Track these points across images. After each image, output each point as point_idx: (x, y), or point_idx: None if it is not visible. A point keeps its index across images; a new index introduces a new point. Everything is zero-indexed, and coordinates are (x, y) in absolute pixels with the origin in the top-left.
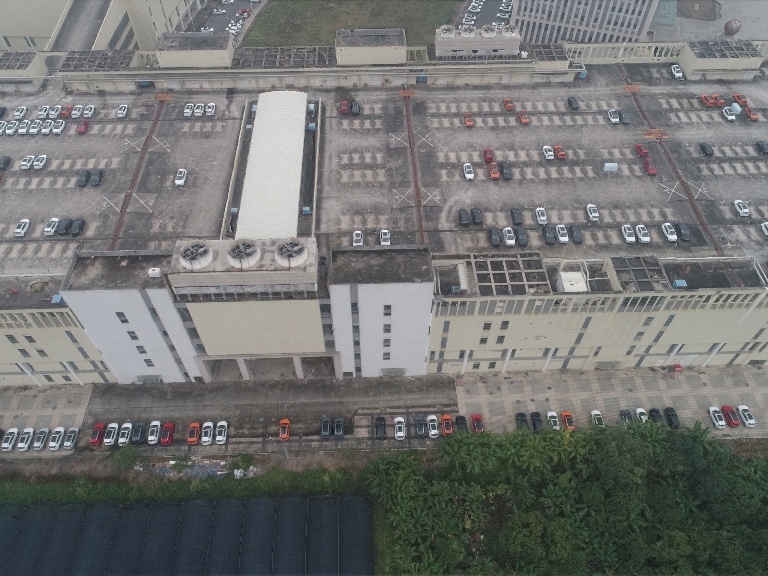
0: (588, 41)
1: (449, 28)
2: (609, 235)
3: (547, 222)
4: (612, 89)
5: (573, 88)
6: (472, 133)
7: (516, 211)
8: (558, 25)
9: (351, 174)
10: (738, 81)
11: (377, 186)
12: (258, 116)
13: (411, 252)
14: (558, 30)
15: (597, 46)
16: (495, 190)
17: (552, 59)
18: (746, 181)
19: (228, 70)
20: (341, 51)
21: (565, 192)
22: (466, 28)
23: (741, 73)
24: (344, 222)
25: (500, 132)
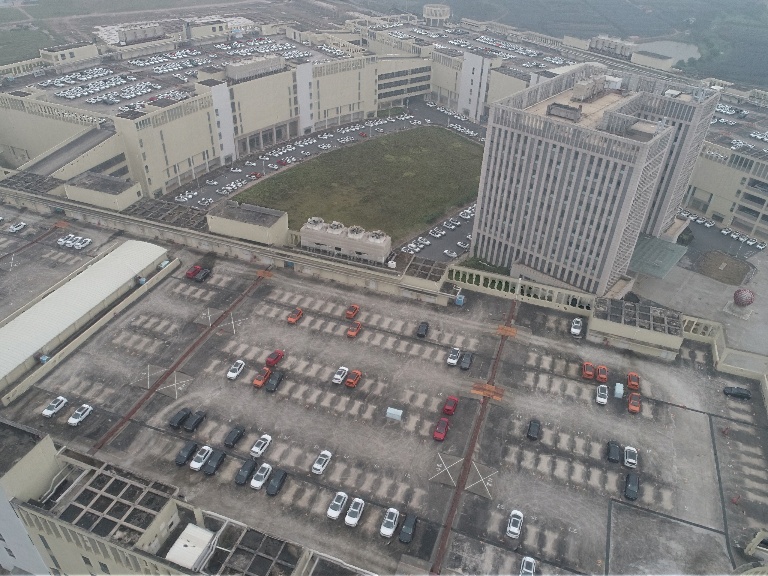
0: (547, 271)
1: (318, 220)
2: (318, 498)
3: (264, 455)
4: (484, 326)
5: (441, 313)
6: (287, 330)
7: (236, 430)
8: (517, 248)
9: (128, 337)
10: (651, 358)
11: (138, 356)
12: (103, 259)
13: (28, 437)
14: (517, 253)
15: (488, 275)
16: (246, 399)
17: (423, 276)
18: (556, 488)
19: (116, 213)
20: (212, 219)
21: (318, 426)
22: (336, 224)
23: (653, 349)
24: (69, 383)
25: (316, 338)
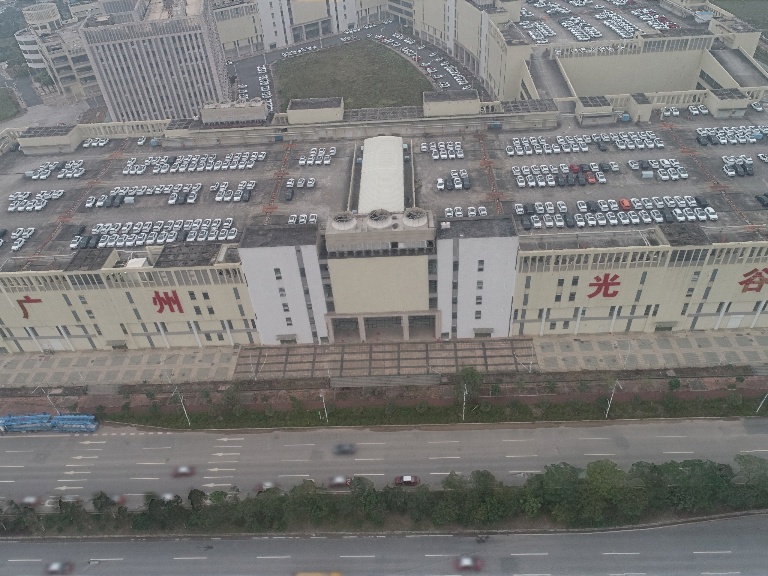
0: None
1: None
2: None
3: None
4: None
5: None
6: None
7: None
8: None
9: None
10: None
11: None
12: None
13: None
14: None
15: None
16: None
17: None
18: None
19: None
20: None
21: None
22: None
23: None
24: None
25: None
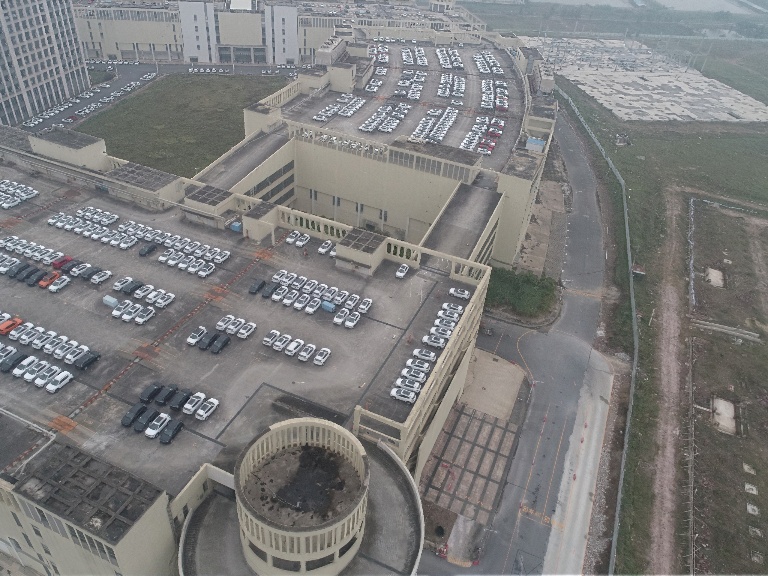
0: None
1: None
2: None
3: None
4: None
5: None
6: None
7: None
8: None
9: None
10: None
11: None
12: None
13: None
14: None
15: (74, 8)
16: None
17: (105, 5)
18: None
19: None
20: None
21: None
22: None
23: None
24: (217, 2)
25: None
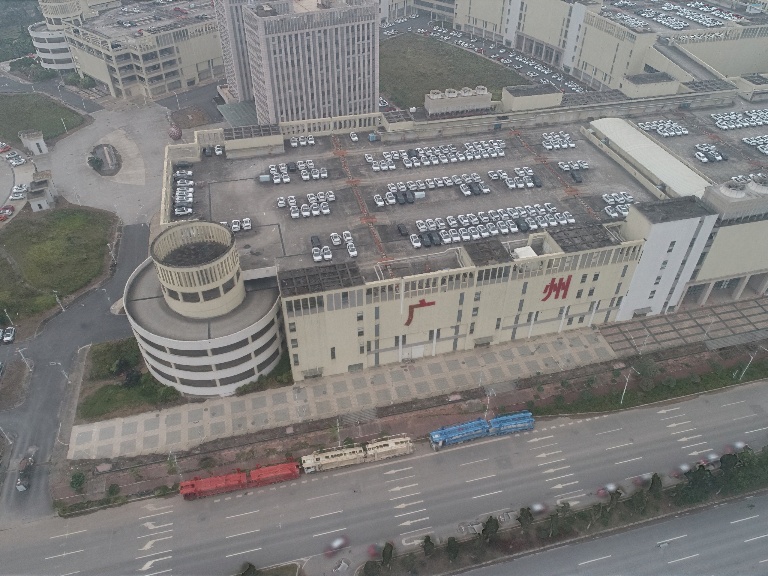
0: None
1: None
2: None
3: None
4: None
5: None
6: None
7: None
8: None
9: None
10: None
11: None
12: None
13: None
14: None
15: None
16: None
17: None
18: None
19: None
20: None
21: None
22: None
23: None
24: None
25: None
